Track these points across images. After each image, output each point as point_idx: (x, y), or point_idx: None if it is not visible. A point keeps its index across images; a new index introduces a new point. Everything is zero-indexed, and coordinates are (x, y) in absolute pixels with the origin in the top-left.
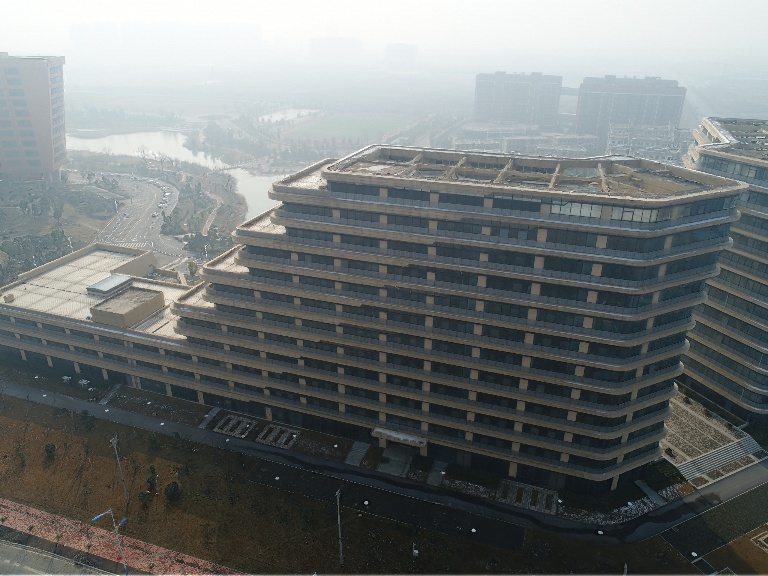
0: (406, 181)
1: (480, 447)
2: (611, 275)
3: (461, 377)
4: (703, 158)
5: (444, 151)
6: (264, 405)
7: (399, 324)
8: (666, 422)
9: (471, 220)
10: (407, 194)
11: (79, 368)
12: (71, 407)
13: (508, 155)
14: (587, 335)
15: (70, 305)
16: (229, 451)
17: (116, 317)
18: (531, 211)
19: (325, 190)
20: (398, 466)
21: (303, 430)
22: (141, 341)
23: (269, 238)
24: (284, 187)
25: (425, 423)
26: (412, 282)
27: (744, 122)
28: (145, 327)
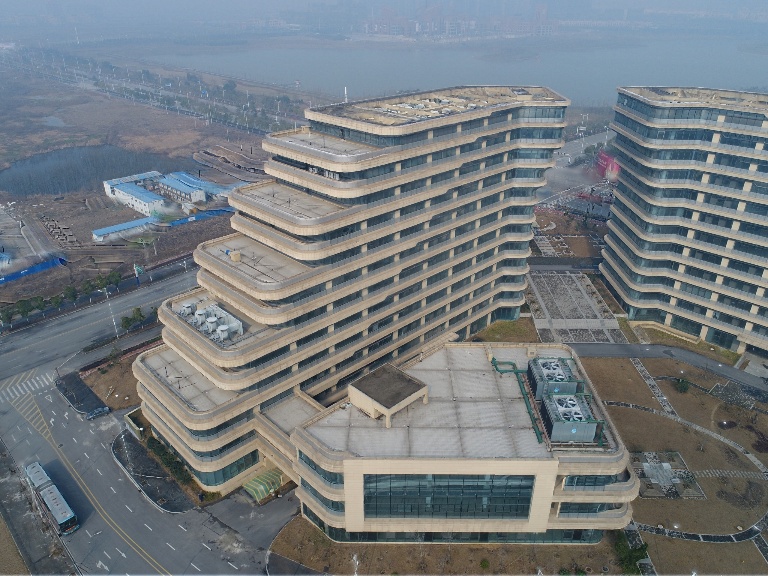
0: None
1: None
2: None
3: None
4: None
5: None
6: None
7: None
8: (564, 290)
9: None
10: None
11: None
12: None
13: None
14: None
15: None
16: None
17: None
18: None
19: None
20: None
21: None
22: None
23: None
24: None
25: None
26: None
27: None
28: None
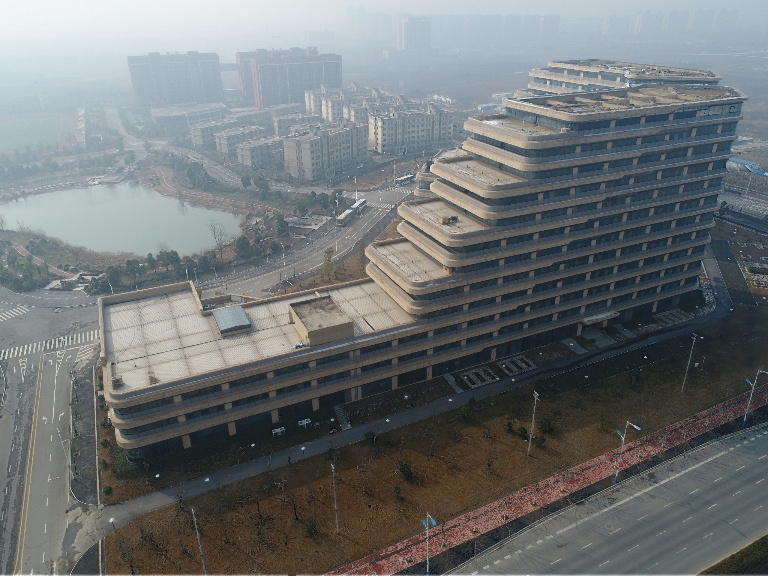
0: (632, 111)
1: (640, 300)
2: (720, 149)
3: (637, 252)
4: (635, 82)
5: (556, 95)
6: (492, 348)
7: (606, 227)
8: None
9: (660, 132)
10: (627, 121)
11: (278, 415)
12: (328, 447)
13: (594, 91)
14: (707, 192)
15: (235, 352)
16: (511, 390)
17: (343, 328)
18: (692, 117)
19: (573, 131)
20: (604, 339)
21: (523, 353)
22: (378, 341)
23: (523, 186)
24: (543, 136)
25: (610, 299)
26: (620, 190)
27: (570, 62)
28: (358, 330)
